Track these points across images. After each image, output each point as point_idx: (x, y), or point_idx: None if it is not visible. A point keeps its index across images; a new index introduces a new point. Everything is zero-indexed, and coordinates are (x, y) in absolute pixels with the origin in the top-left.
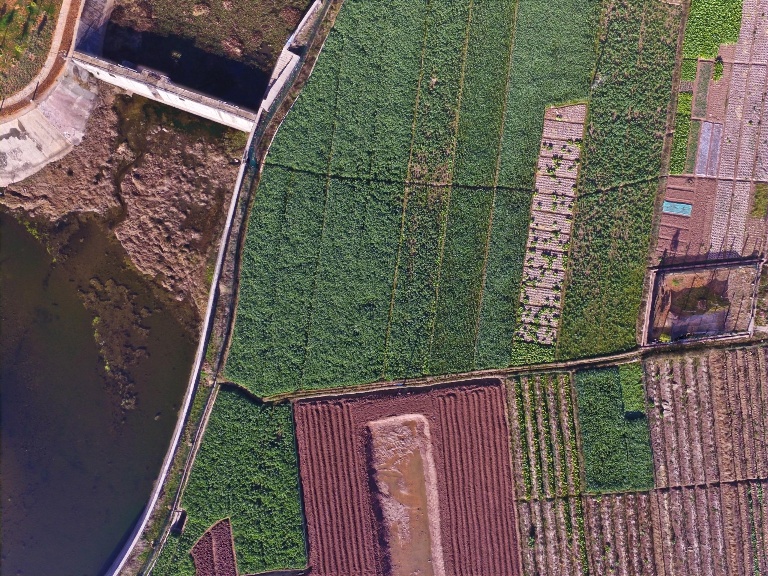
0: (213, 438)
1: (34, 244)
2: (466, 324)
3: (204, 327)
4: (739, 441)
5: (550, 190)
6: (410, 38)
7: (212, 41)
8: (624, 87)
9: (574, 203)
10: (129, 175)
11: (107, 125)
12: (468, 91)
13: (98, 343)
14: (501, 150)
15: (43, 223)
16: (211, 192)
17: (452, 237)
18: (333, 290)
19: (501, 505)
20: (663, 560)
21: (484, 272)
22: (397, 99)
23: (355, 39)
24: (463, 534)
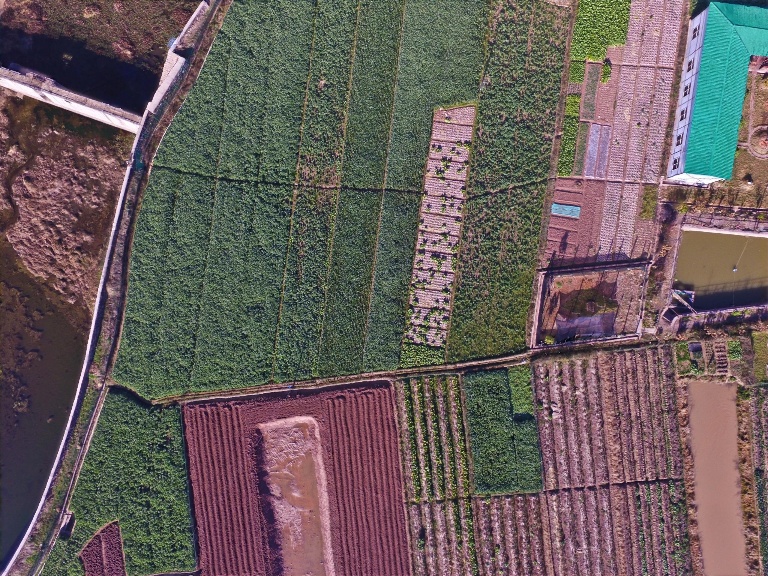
0: (100, 441)
1: None
2: (355, 326)
3: (90, 330)
4: (627, 443)
5: (439, 192)
6: (297, 40)
7: (103, 43)
8: (512, 89)
9: (463, 205)
10: (20, 177)
11: None
12: (356, 93)
13: None
14: (389, 152)
15: None
16: (103, 194)
17: (340, 239)
18: (221, 292)
19: (391, 507)
20: (552, 562)
21: (373, 274)
22: (284, 101)
23: (242, 41)
24: (353, 536)
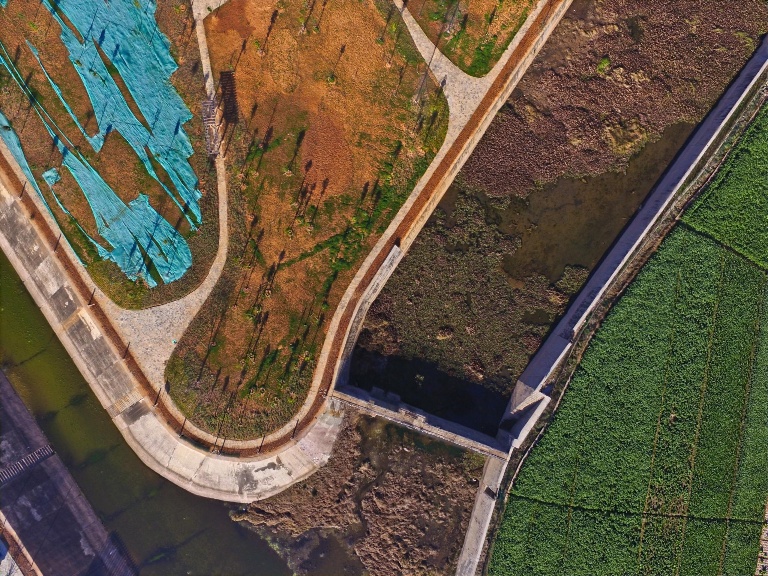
0: None
1: (275, 558)
2: None
3: None
4: None
5: None
6: (653, 378)
7: (454, 364)
8: None
9: None
10: (370, 493)
11: (351, 445)
12: (706, 428)
13: None
14: (736, 486)
15: (285, 538)
16: (449, 510)
17: (686, 567)
18: None
19: None
20: None
21: None
22: (640, 437)
23: (601, 378)
24: None
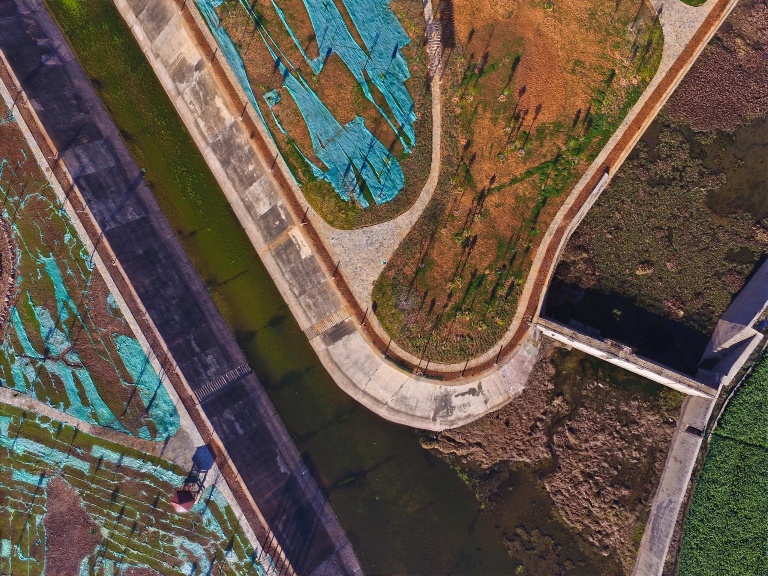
0: None
1: (463, 489)
2: None
3: None
4: None
5: None
6: None
7: (653, 300)
8: None
9: None
10: (563, 428)
11: (545, 378)
12: None
13: None
14: None
15: (474, 469)
16: (643, 450)
17: None
18: None
19: None
20: None
21: None
22: None
23: None
24: None
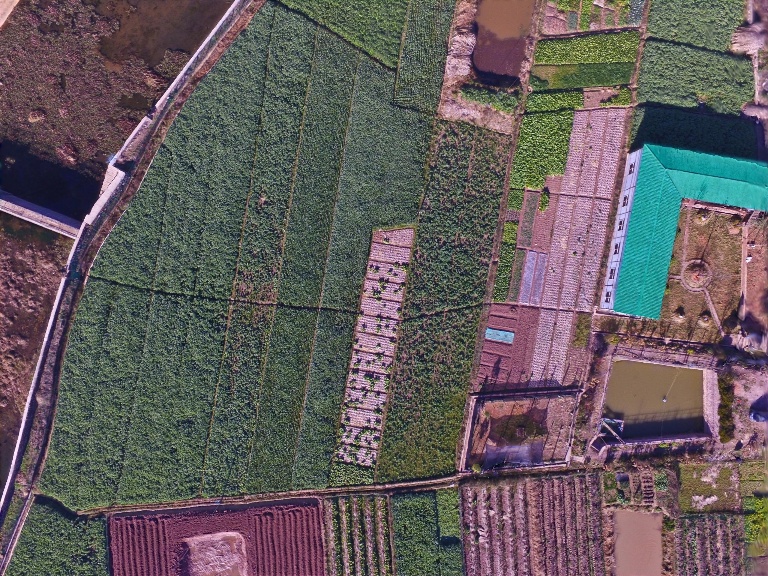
0: (23, 552)
1: None
2: (285, 444)
3: (17, 440)
4: (552, 570)
5: (375, 312)
6: (239, 158)
7: (46, 148)
8: (451, 214)
9: (398, 326)
10: None
11: None
12: (295, 212)
13: None
14: (326, 272)
15: None
16: (39, 299)
17: (274, 356)
18: (151, 406)
19: None
20: None
21: (305, 392)
22: (223, 218)
23: (183, 156)
24: None
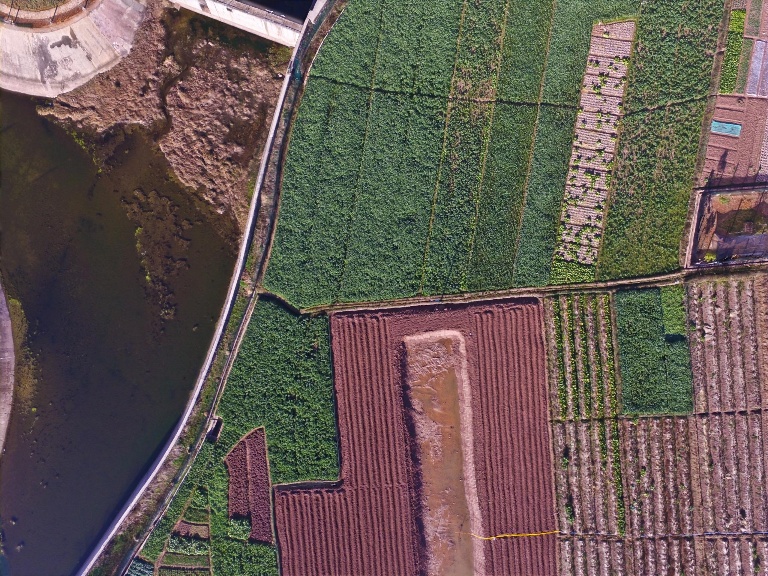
0: (251, 346)
1: (81, 154)
2: (506, 241)
3: (245, 236)
4: None
5: (595, 108)
6: None
7: None
8: (675, 4)
9: (619, 121)
10: (174, 88)
11: (154, 38)
12: (515, 6)
13: (140, 253)
14: (546, 66)
15: (90, 134)
16: (254, 106)
17: (494, 153)
18: (373, 203)
19: (535, 425)
20: (700, 486)
21: (525, 189)
22: (443, 12)
23: None
24: (496, 452)
